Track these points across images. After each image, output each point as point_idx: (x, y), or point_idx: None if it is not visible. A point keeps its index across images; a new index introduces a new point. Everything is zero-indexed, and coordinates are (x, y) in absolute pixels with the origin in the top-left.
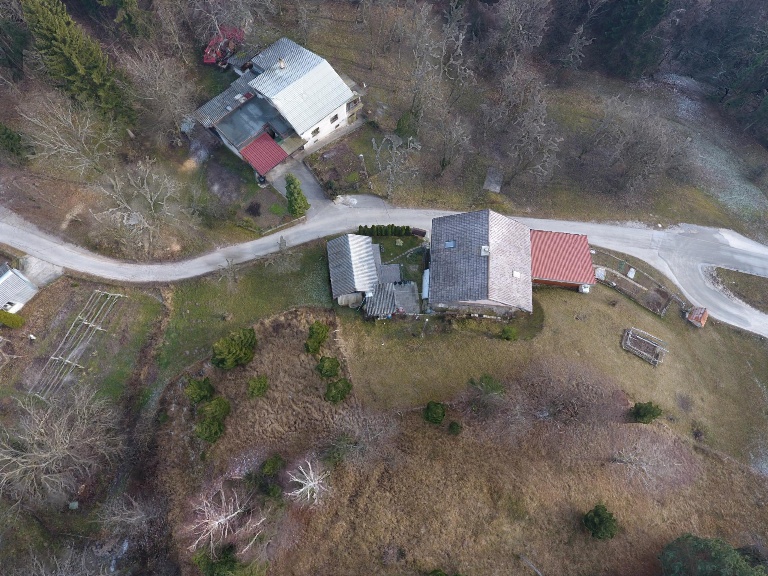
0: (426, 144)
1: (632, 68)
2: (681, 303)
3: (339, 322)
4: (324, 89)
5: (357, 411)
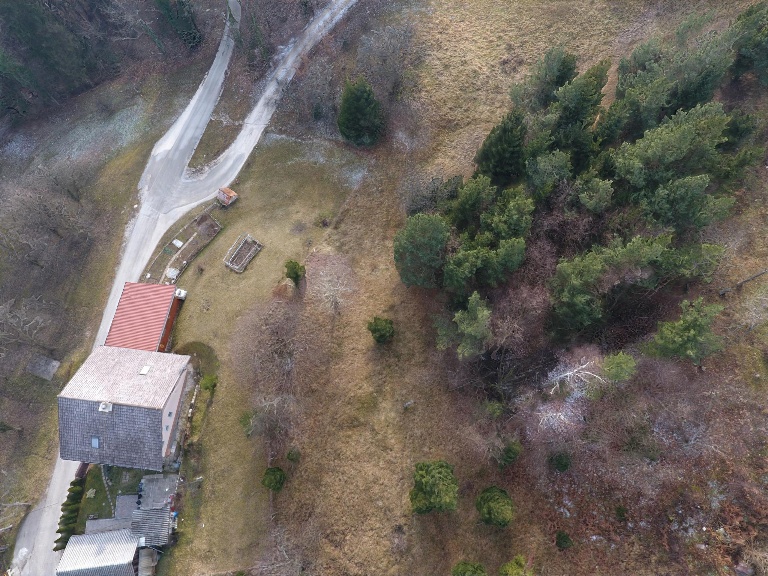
0: None
1: None
2: (214, 206)
3: None
4: None
5: (266, 567)
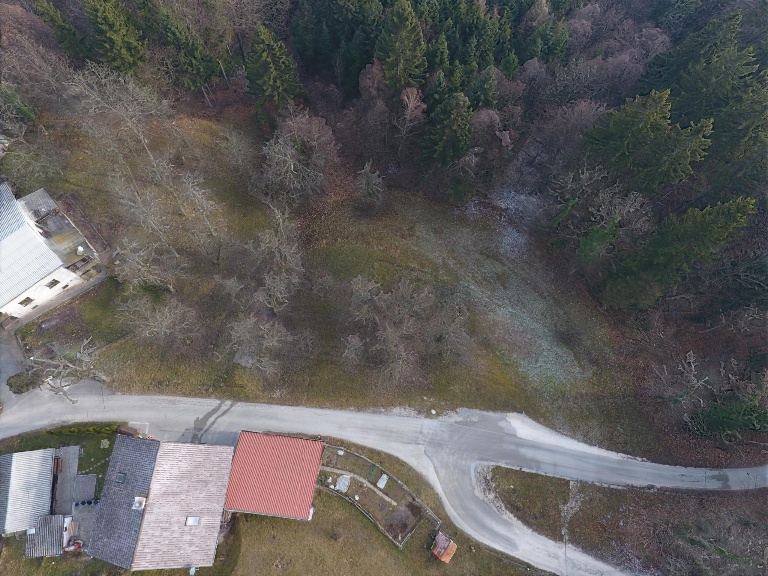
0: (186, 298)
1: (450, 196)
2: (436, 522)
3: (4, 556)
4: (23, 259)
5: None
